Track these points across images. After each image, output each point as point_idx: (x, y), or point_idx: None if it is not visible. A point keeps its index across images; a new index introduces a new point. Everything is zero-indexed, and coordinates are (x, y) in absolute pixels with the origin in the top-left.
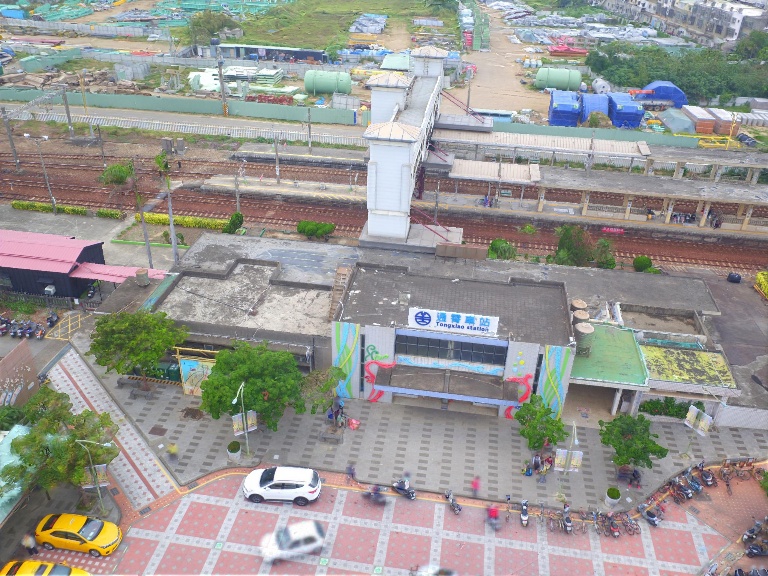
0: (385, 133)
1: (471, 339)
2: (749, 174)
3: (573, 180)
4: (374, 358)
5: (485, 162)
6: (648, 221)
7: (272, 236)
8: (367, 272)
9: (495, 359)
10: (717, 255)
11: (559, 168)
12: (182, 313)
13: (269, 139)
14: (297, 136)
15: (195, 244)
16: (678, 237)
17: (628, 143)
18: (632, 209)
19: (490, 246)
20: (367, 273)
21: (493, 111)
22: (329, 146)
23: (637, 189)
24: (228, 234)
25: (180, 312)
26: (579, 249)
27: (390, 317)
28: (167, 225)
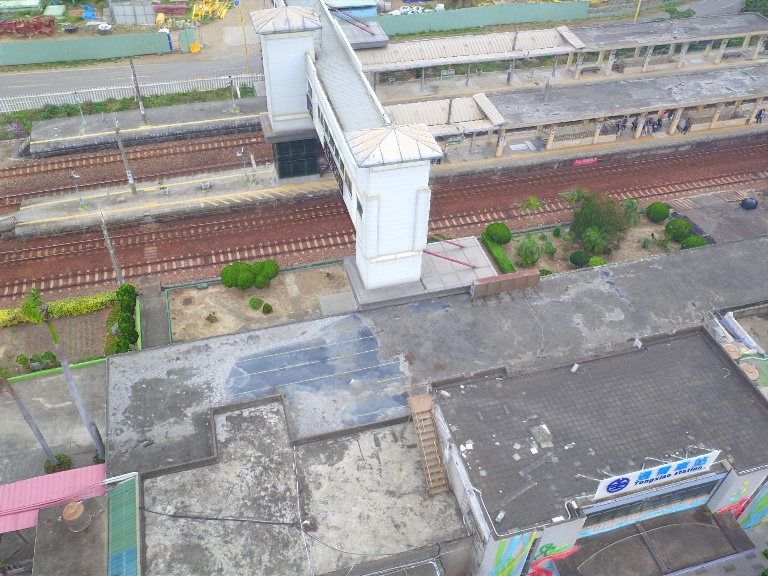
0: (391, 152)
1: (680, 486)
2: (673, 46)
3: (536, 110)
4: (548, 554)
5: (418, 103)
6: (617, 140)
7: (184, 299)
8: (451, 394)
9: (699, 491)
10: (705, 170)
11: (472, 77)
12: (197, 575)
13: (64, 106)
14: (106, 93)
15: (110, 391)
16: (653, 153)
17: (547, 32)
18: (601, 130)
19: (483, 234)
20: (453, 396)
21: (351, 2)
22: (160, 100)
23: (611, 107)
24: (151, 349)
25: (192, 574)
26: (613, 224)
27: (551, 484)
28: (2, 328)
